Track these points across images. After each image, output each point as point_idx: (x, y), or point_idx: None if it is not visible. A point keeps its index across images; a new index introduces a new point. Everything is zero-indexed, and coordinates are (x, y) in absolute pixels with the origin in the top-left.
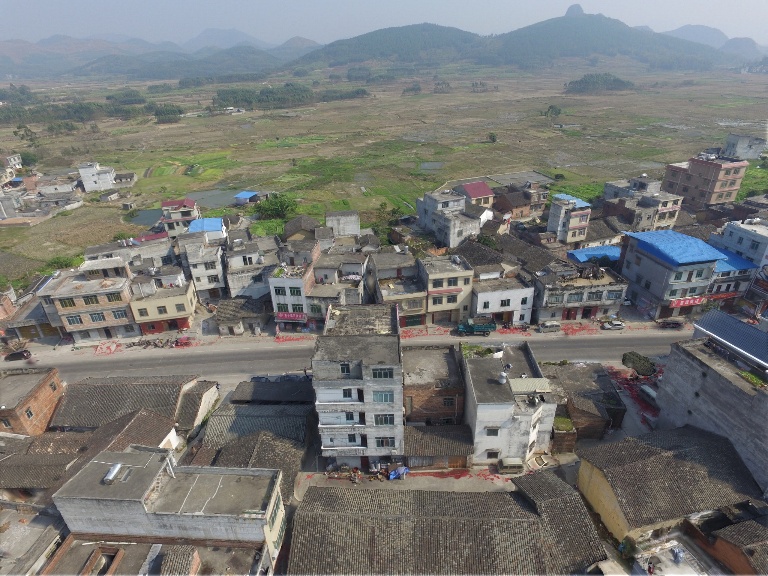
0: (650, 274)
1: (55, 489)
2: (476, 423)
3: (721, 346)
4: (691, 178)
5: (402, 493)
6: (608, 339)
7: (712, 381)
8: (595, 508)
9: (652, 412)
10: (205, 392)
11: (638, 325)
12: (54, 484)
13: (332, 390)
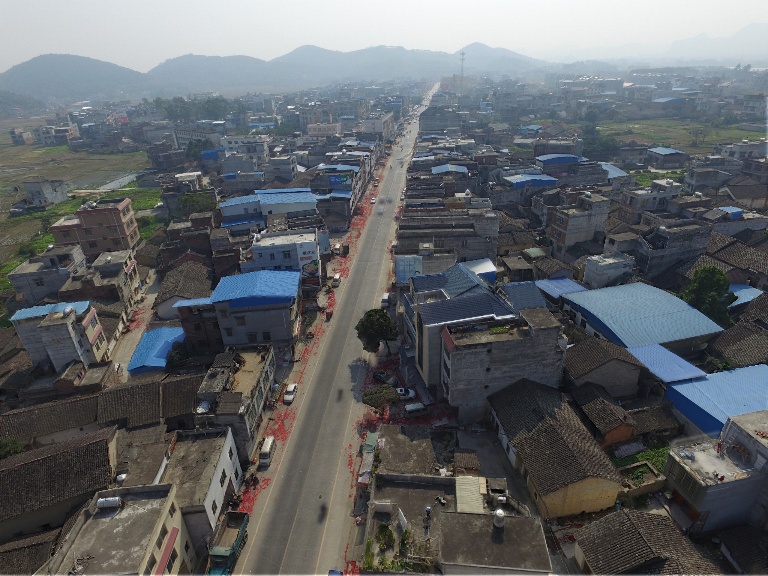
0: (264, 325)
1: None
2: None
3: (459, 326)
4: (91, 231)
5: None
6: (310, 407)
7: (498, 350)
8: (577, 512)
9: (433, 419)
10: None
11: (295, 375)
12: None
13: None
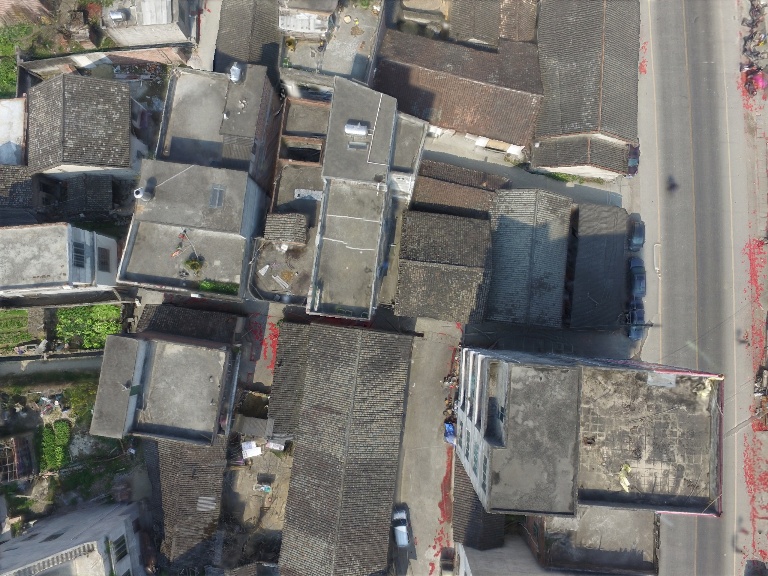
0: None
1: (424, 49)
2: (470, 567)
3: None
4: None
5: (392, 445)
6: None
7: None
8: None
9: None
10: (596, 165)
11: None
12: (438, 42)
13: None
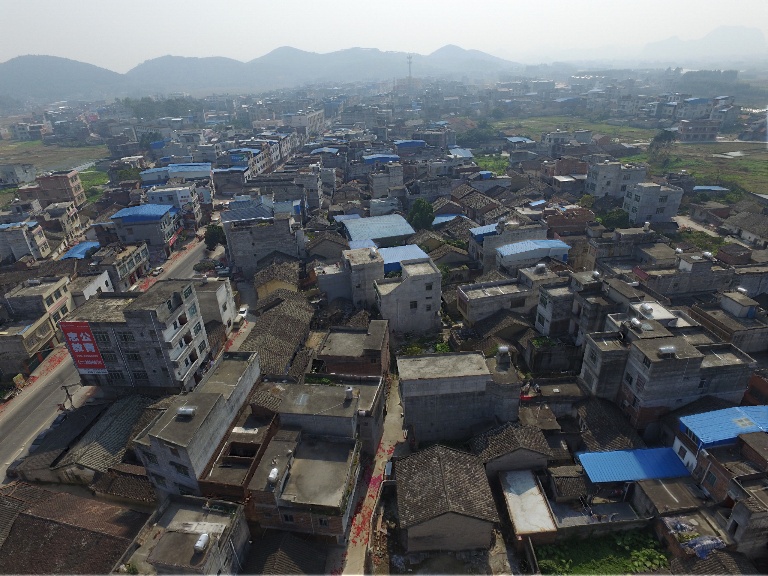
0: (145, 234)
1: (98, 568)
2: (219, 306)
3: None
4: (48, 193)
5: None
6: (167, 277)
7: (256, 232)
8: None
9: None
10: None
11: (165, 265)
12: None
13: (170, 327)
